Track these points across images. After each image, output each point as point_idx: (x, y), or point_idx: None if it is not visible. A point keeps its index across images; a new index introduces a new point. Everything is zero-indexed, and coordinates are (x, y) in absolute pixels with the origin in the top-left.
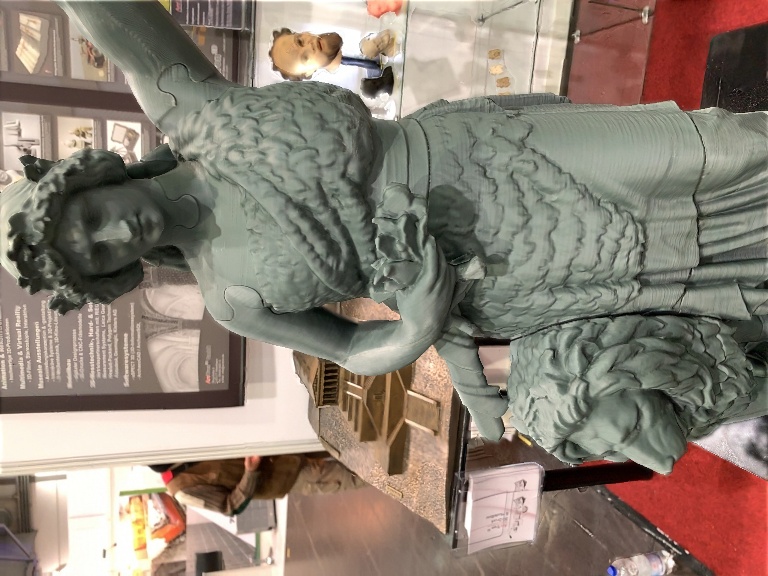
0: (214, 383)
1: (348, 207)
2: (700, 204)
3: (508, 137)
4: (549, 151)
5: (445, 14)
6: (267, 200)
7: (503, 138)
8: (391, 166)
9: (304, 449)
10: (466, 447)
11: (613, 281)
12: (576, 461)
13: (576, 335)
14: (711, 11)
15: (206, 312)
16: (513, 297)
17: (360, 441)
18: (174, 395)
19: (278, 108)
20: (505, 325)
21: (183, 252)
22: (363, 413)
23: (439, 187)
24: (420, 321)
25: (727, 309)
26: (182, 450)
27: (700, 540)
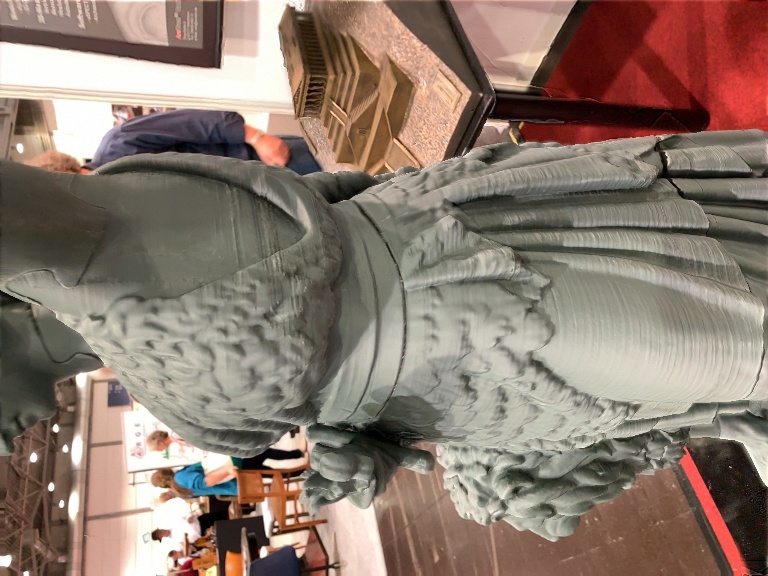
0: (186, 39)
1: None
2: None
3: (514, 349)
4: (559, 369)
5: None
6: (179, 431)
7: (506, 352)
8: (348, 374)
9: (284, 113)
10: None
11: None
12: None
13: (516, 464)
14: None
15: None
16: None
17: (337, 162)
18: (139, 46)
19: (191, 358)
20: None
21: None
22: (344, 139)
23: (403, 397)
24: None
25: (691, 424)
26: (153, 96)
27: None
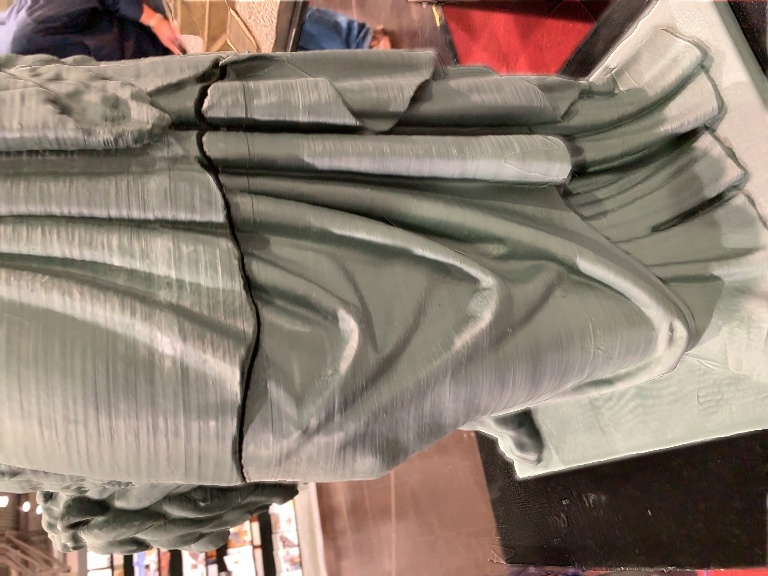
0: None
1: None
2: None
3: None
4: None
5: None
6: None
7: None
8: None
9: None
10: None
11: None
12: None
13: None
14: None
15: None
16: None
17: None
18: None
19: None
20: None
21: None
22: (182, 5)
23: None
24: None
25: None
26: None
27: None
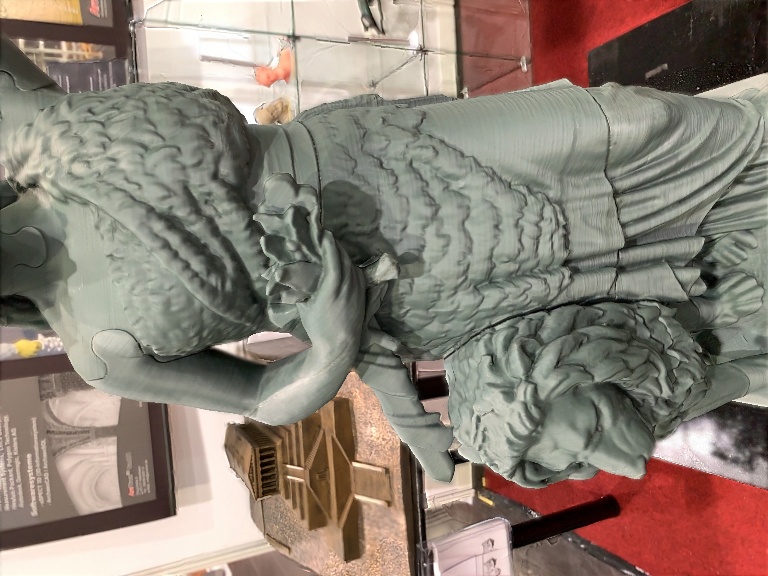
0: (139, 495)
1: (227, 214)
2: (613, 181)
3: (400, 125)
4: (447, 135)
5: (337, 84)
6: (123, 212)
7: (395, 126)
8: (273, 166)
9: (251, 553)
10: (424, 513)
11: (541, 270)
12: (540, 484)
13: (512, 335)
14: (581, 51)
15: (122, 415)
16: (436, 300)
17: (309, 529)
18: (93, 516)
19: (126, 107)
20: (433, 336)
21: (35, 303)
22: (308, 497)
23: (332, 183)
24: (331, 336)
25: (663, 290)
26: None
27: (681, 570)
